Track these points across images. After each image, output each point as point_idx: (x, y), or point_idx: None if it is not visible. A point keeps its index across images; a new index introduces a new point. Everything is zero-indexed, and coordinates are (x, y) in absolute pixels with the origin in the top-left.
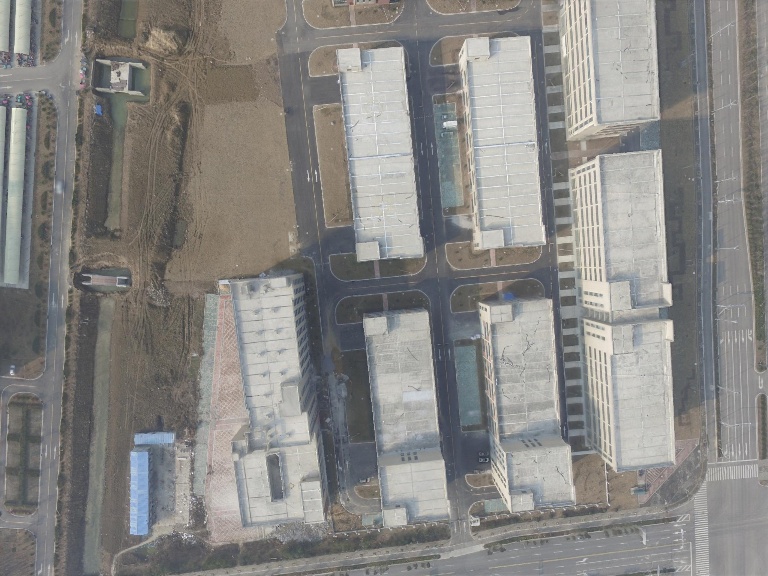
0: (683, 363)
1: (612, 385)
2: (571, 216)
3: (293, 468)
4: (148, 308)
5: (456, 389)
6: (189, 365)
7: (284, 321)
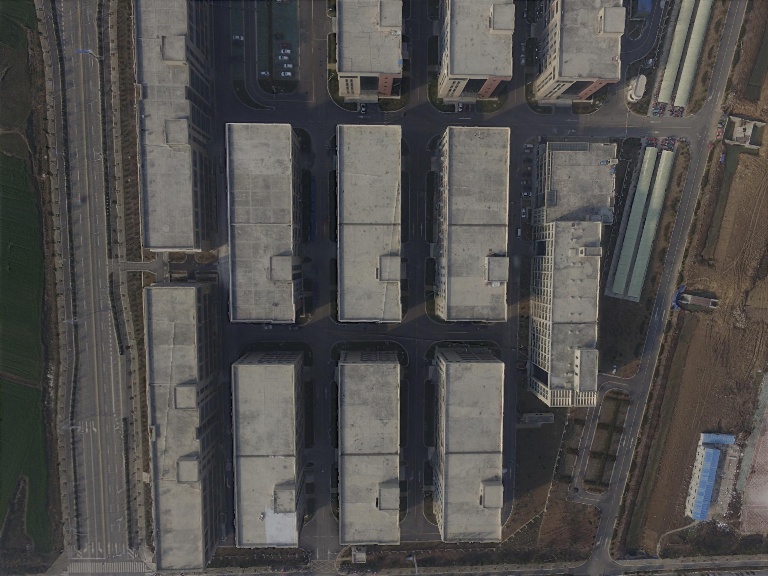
0: None
1: None
2: None
3: None
4: (732, 328)
5: None
6: (753, 379)
7: None
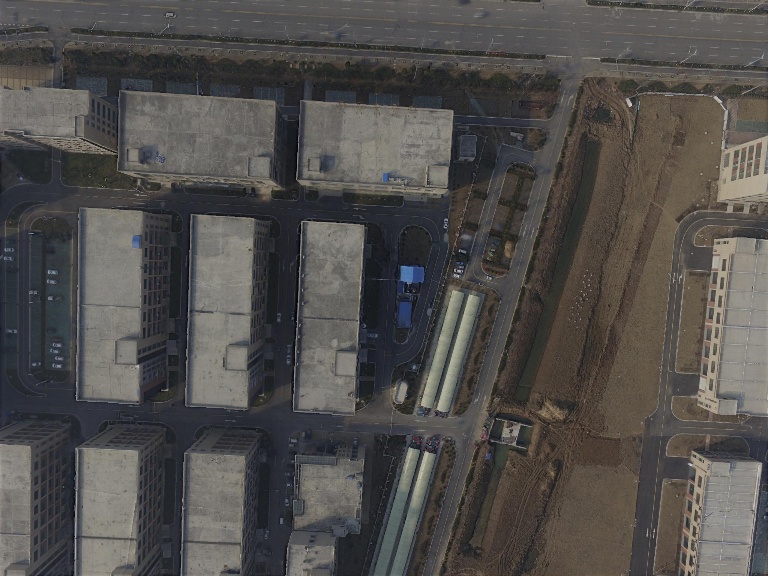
0: None
1: None
2: None
3: None
4: None
5: None
6: None
7: None
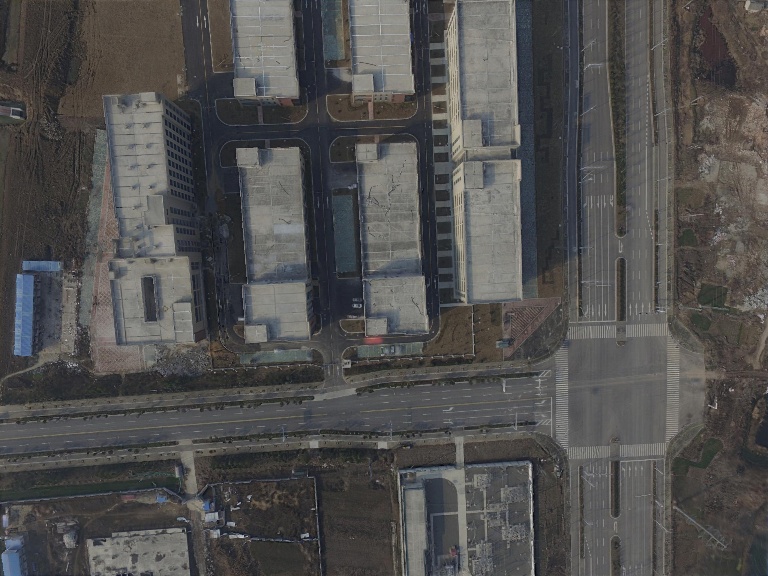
0: (548, 223)
1: (465, 221)
2: (445, 75)
3: (167, 291)
4: (40, 139)
5: (333, 236)
6: (78, 198)
7: (154, 137)
